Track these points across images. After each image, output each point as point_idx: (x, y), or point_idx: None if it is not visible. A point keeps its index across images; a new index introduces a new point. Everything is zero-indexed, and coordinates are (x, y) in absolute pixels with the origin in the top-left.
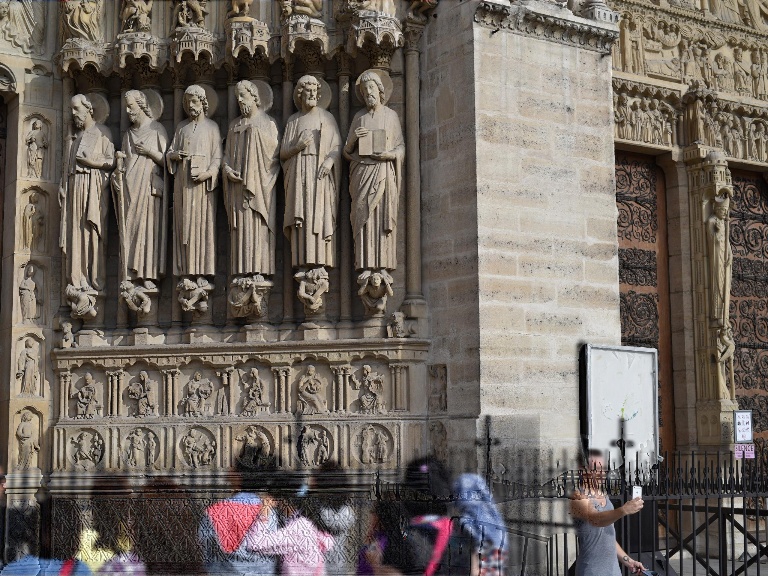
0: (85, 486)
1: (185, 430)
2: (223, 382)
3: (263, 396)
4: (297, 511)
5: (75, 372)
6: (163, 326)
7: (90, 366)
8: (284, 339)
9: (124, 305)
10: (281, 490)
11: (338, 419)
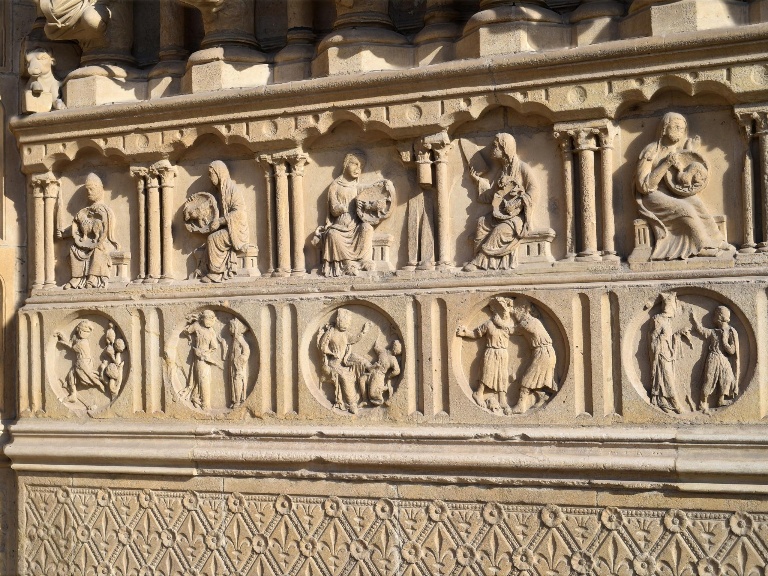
0: (85, 456)
1: (321, 311)
2: (418, 177)
3: (531, 212)
4: (643, 548)
5: (66, 174)
6: (268, 47)
7: (98, 157)
8: (588, 44)
9: (173, 1)
10: (592, 484)
11: (766, 270)
